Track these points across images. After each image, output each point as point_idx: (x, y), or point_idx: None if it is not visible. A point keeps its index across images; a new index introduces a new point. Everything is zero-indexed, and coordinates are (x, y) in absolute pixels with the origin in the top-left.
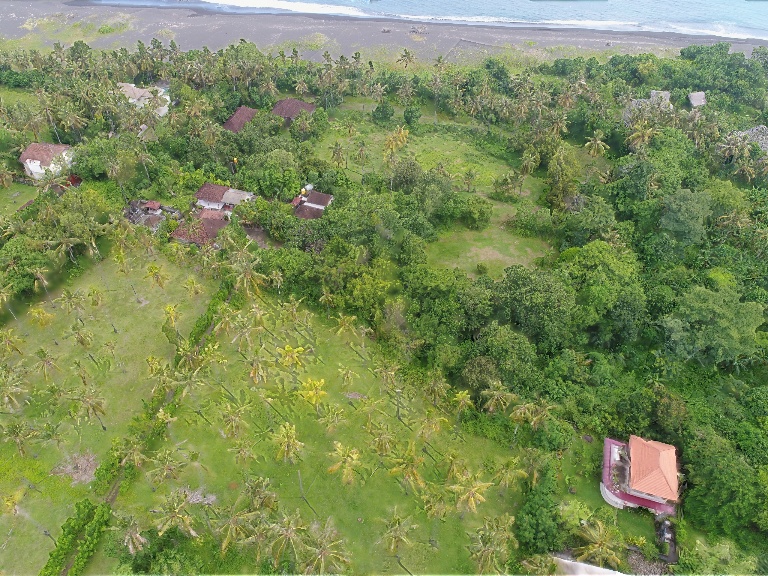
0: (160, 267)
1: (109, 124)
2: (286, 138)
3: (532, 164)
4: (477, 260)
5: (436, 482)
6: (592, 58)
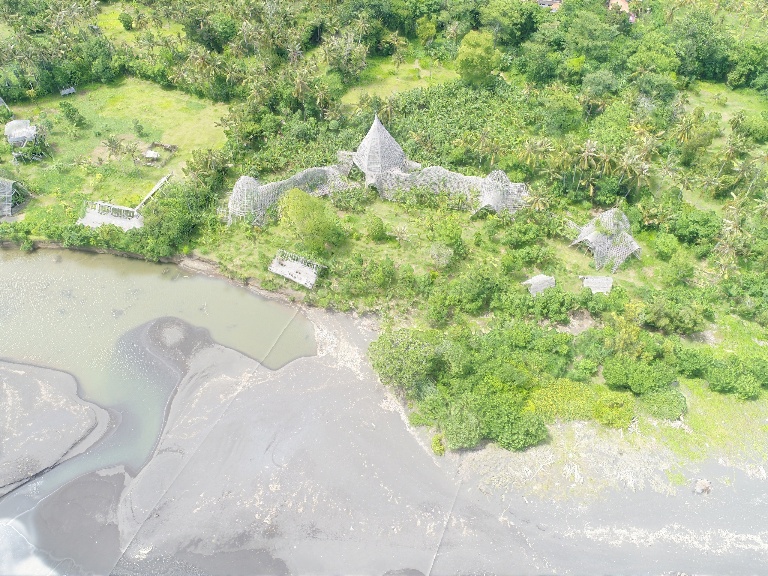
0: None
1: None
2: None
3: (733, 118)
4: (728, 112)
5: None
6: (726, 377)
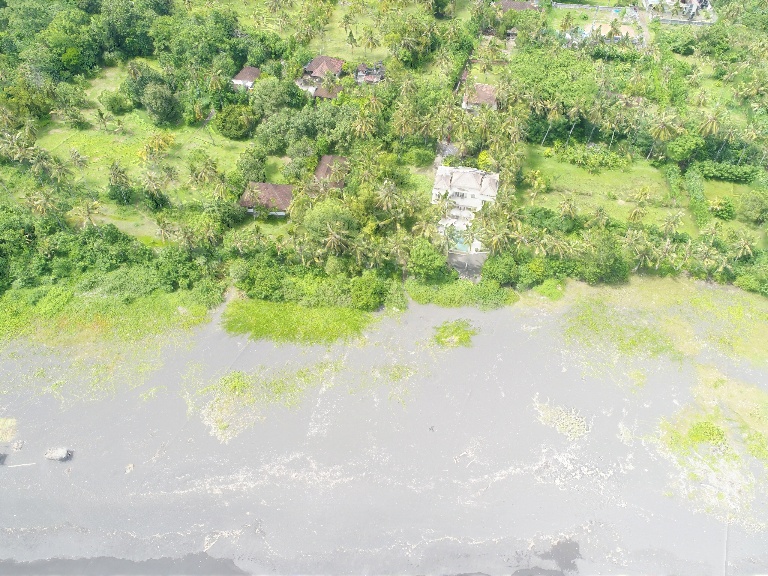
0: (326, 6)
1: (470, 158)
2: (277, 178)
3: None
4: None
5: (200, 4)
6: None
